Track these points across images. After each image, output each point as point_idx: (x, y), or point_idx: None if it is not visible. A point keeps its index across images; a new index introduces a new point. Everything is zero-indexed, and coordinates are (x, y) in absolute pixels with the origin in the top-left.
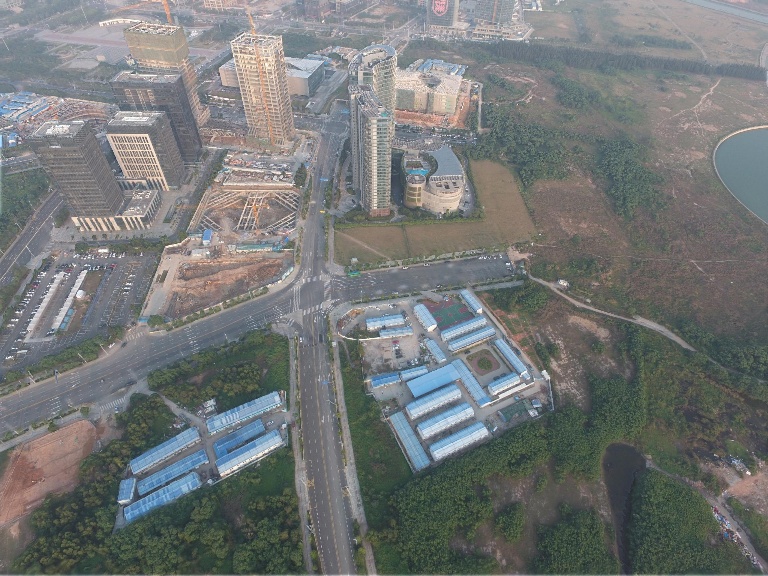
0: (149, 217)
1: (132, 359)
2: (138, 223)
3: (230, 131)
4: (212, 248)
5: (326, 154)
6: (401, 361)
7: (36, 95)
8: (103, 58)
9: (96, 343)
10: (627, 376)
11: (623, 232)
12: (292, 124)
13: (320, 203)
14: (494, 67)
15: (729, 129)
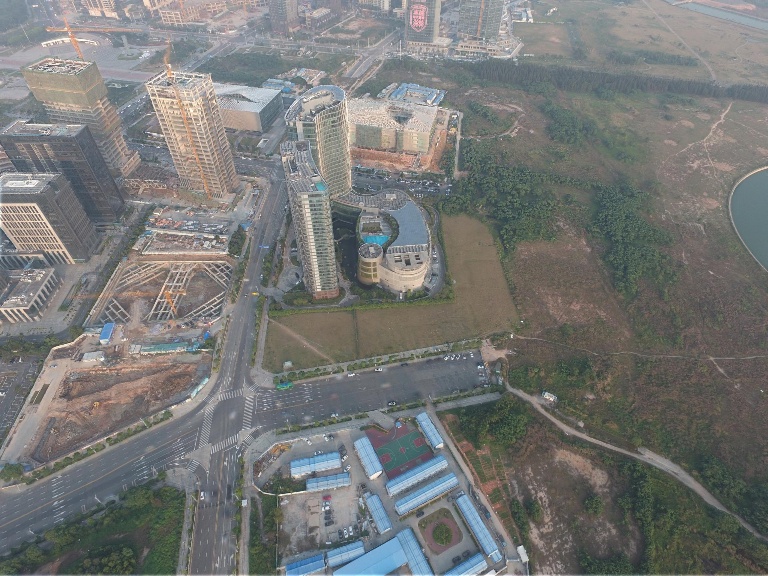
0: (38, 307)
1: None
2: (23, 315)
3: (160, 182)
4: (111, 349)
5: (272, 209)
6: (331, 530)
7: None
8: None
9: None
10: (632, 552)
11: (624, 316)
12: (234, 172)
13: (256, 279)
14: (476, 92)
15: (745, 168)
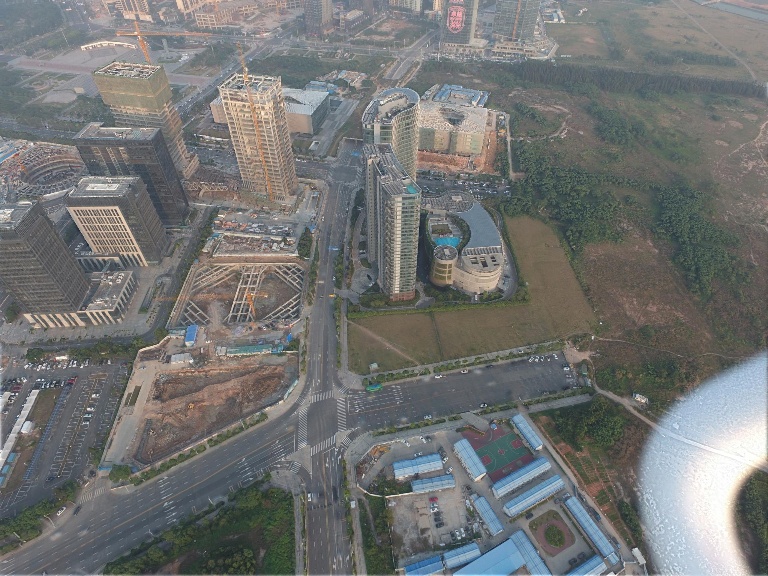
0: (120, 309)
1: (86, 535)
2: (106, 318)
3: (222, 184)
4: (197, 351)
5: (334, 211)
6: (442, 532)
7: (2, 138)
8: (82, 90)
9: (39, 514)
10: (748, 555)
11: (702, 317)
12: (294, 174)
13: (329, 281)
14: (520, 93)
15: None
